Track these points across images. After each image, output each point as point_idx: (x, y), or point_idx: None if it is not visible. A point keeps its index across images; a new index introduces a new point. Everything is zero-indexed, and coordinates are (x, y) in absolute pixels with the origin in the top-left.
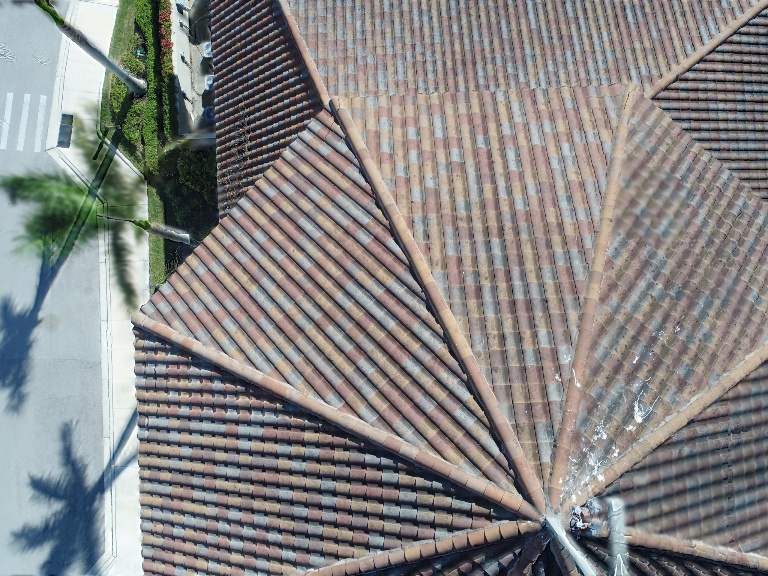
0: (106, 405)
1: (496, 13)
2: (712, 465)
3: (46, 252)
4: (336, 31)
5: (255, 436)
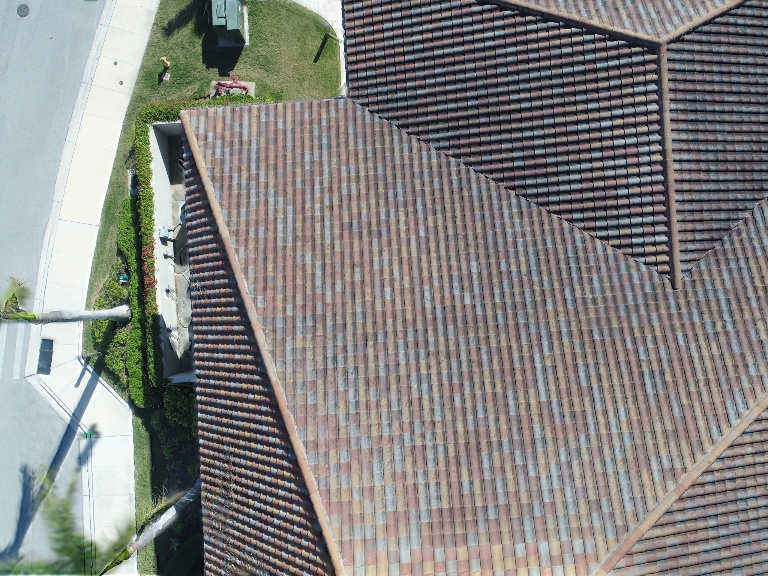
0: None
1: (502, 378)
2: None
3: (26, 485)
4: (327, 402)
5: None
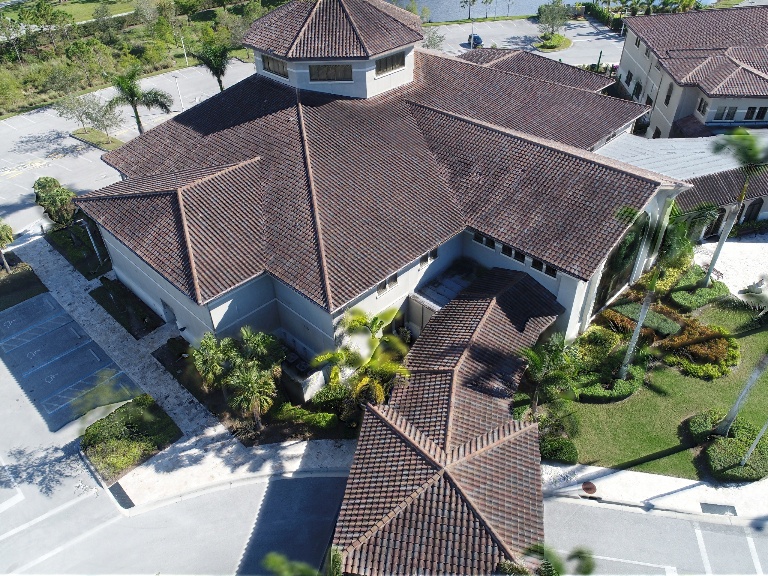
0: None
1: None
2: None
3: None
4: None
5: None
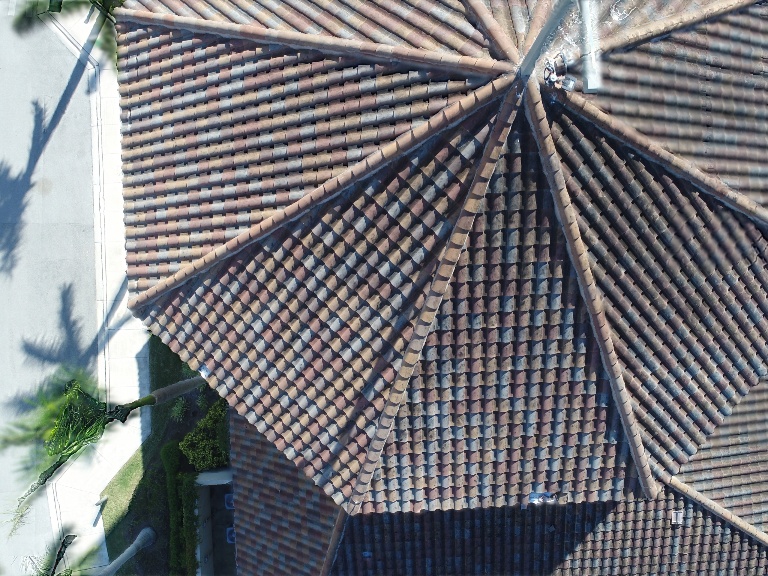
0: (99, 268)
1: None
2: (690, 87)
3: (38, 116)
4: None
5: (235, 89)
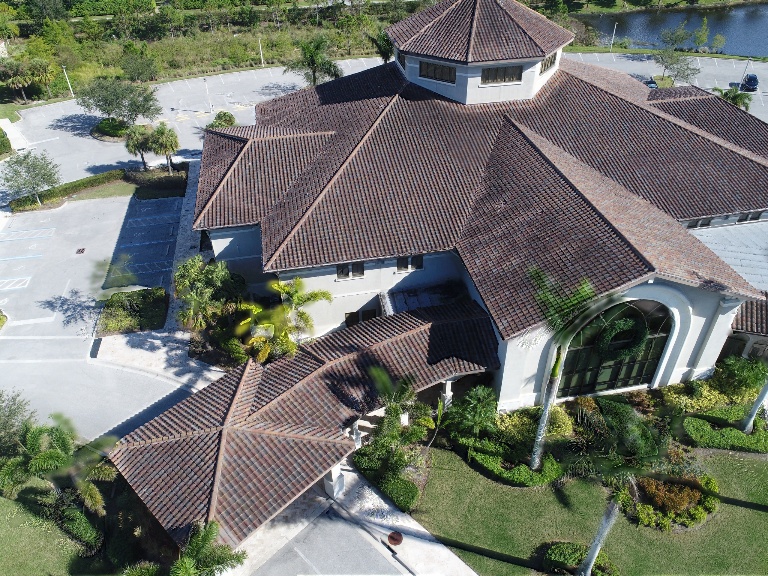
0: None
1: None
2: None
3: None
4: None
5: None
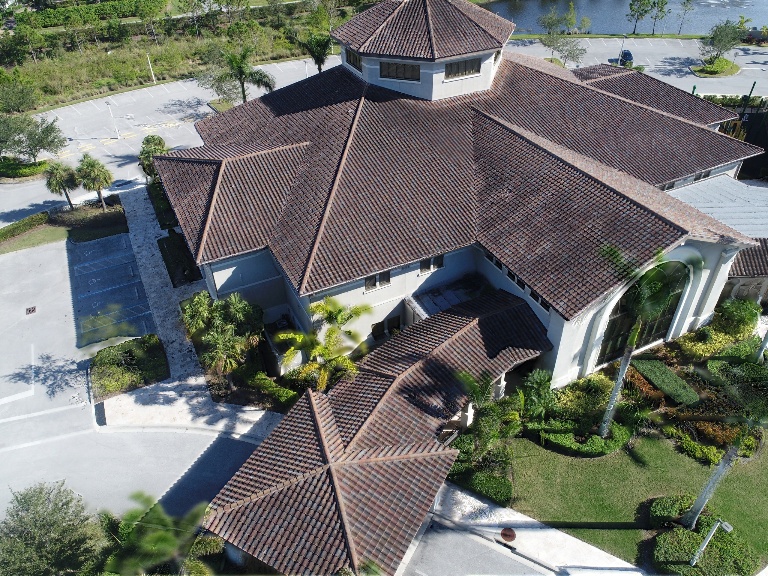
0: None
1: None
2: None
3: None
4: None
5: None
